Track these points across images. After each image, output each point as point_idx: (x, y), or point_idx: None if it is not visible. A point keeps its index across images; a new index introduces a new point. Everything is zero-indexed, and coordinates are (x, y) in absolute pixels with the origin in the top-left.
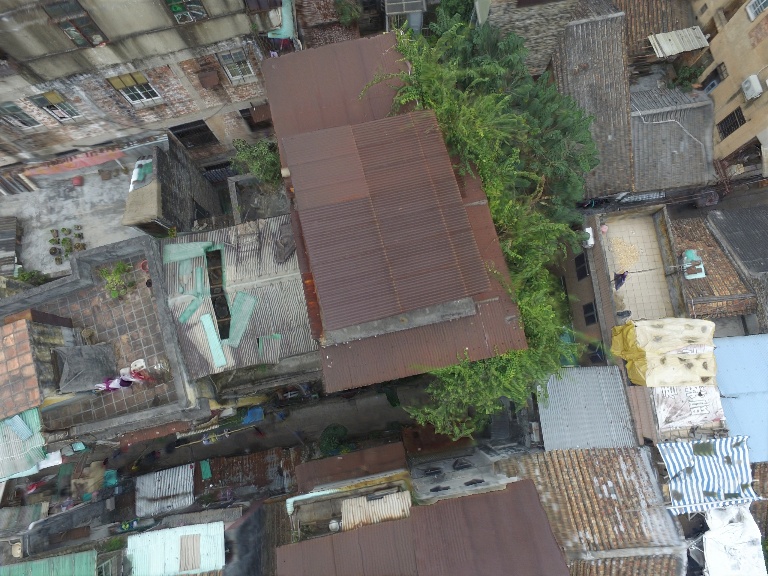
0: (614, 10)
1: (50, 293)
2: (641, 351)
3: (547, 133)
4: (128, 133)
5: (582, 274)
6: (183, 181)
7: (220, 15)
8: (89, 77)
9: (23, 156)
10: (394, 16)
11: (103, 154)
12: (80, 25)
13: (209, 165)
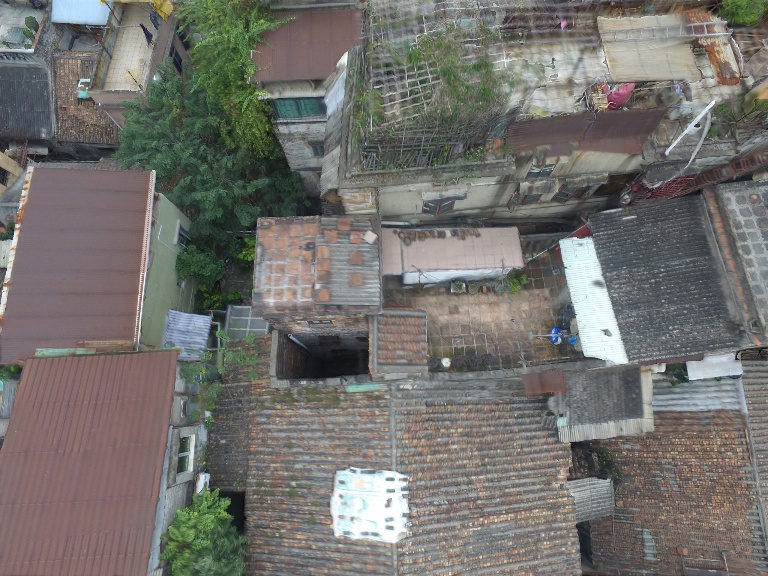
0: None
1: None
2: None
3: (158, 101)
4: None
5: None
6: None
7: None
8: None
9: None
10: None
11: None
12: None
13: None
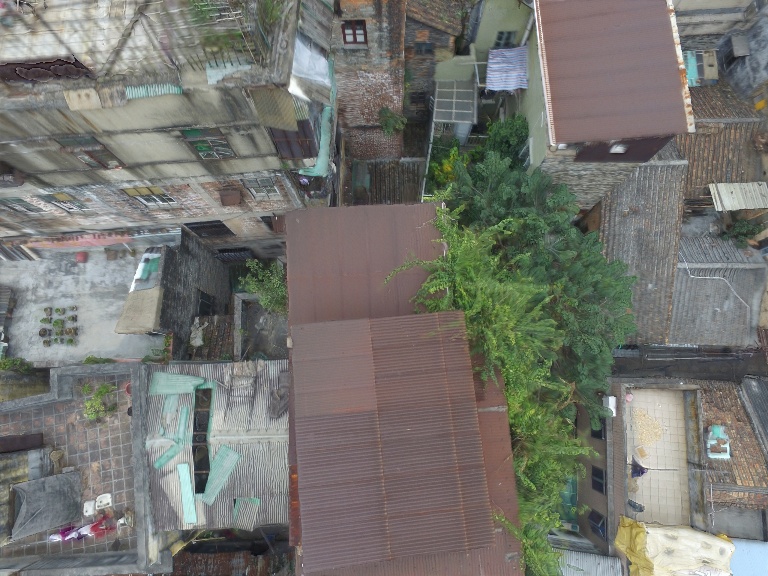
0: (677, 156)
1: (25, 406)
2: (649, 562)
3: (585, 305)
4: (140, 224)
5: (597, 433)
6: (190, 274)
7: (249, 156)
8: (102, 187)
9: (27, 231)
10: (441, 123)
11: (111, 238)
12: (95, 154)
13: (223, 248)
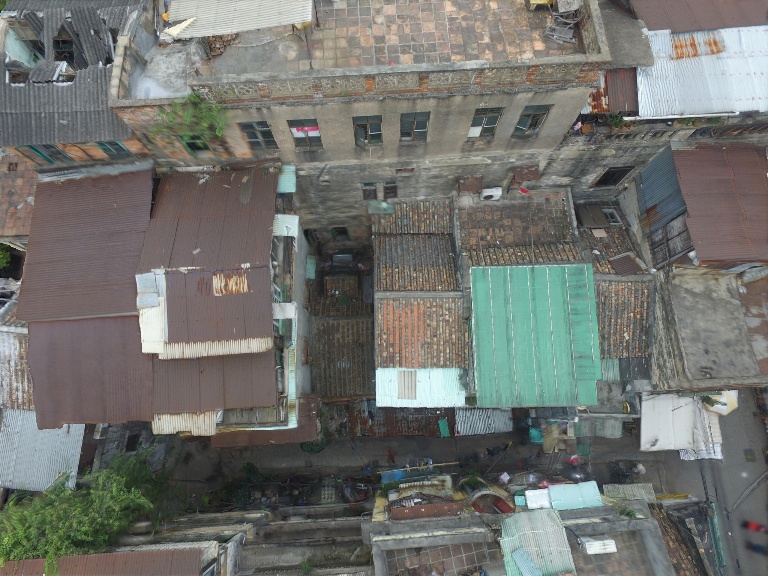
0: None
1: None
2: None
3: None
4: None
5: None
6: None
7: None
8: None
9: None
10: None
11: None
12: None
13: None
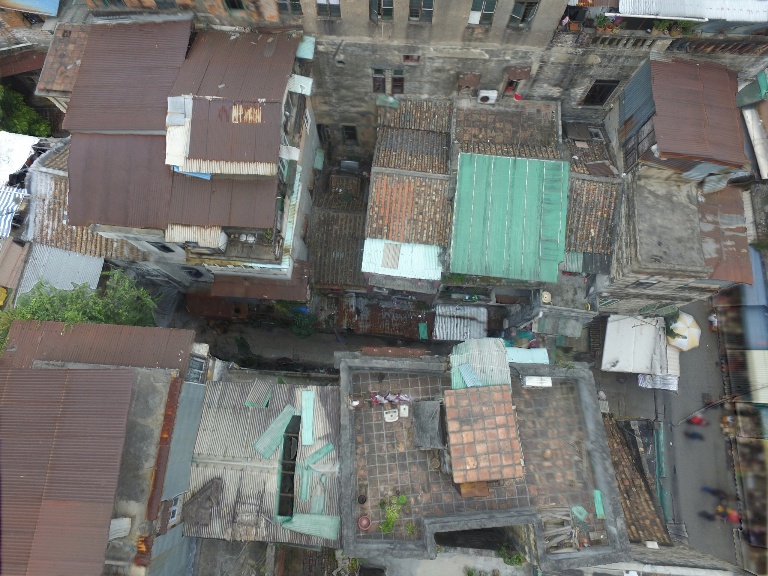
0: None
1: None
2: None
3: None
4: None
5: None
6: None
7: None
8: None
9: None
10: None
11: None
12: None
13: None
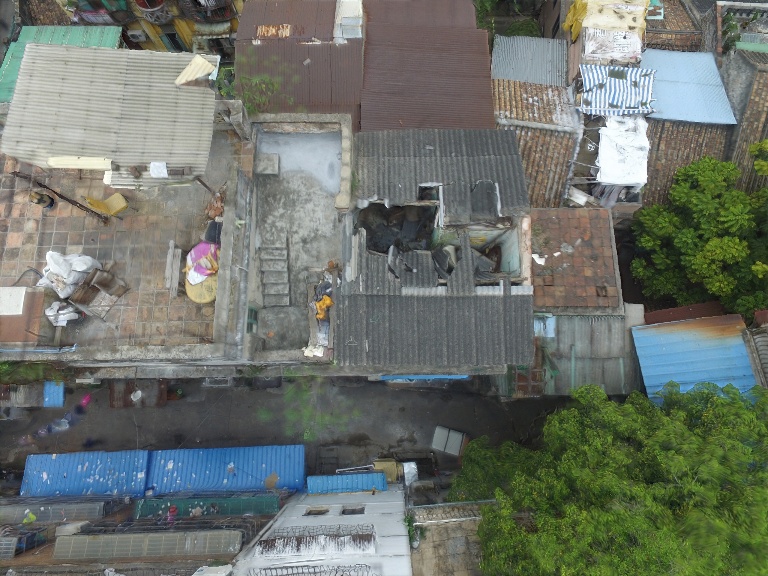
0: None
1: None
2: (584, 4)
3: None
4: None
5: None
6: None
7: None
8: None
9: None
10: None
11: None
12: None
13: None
